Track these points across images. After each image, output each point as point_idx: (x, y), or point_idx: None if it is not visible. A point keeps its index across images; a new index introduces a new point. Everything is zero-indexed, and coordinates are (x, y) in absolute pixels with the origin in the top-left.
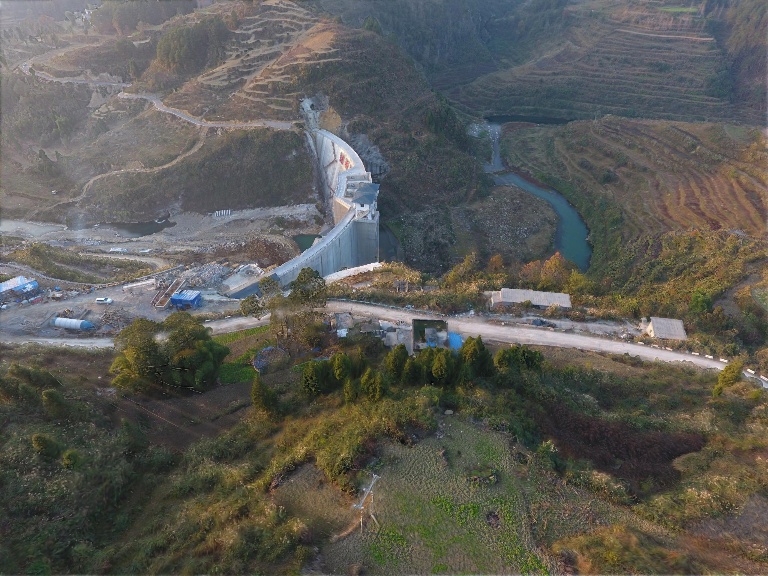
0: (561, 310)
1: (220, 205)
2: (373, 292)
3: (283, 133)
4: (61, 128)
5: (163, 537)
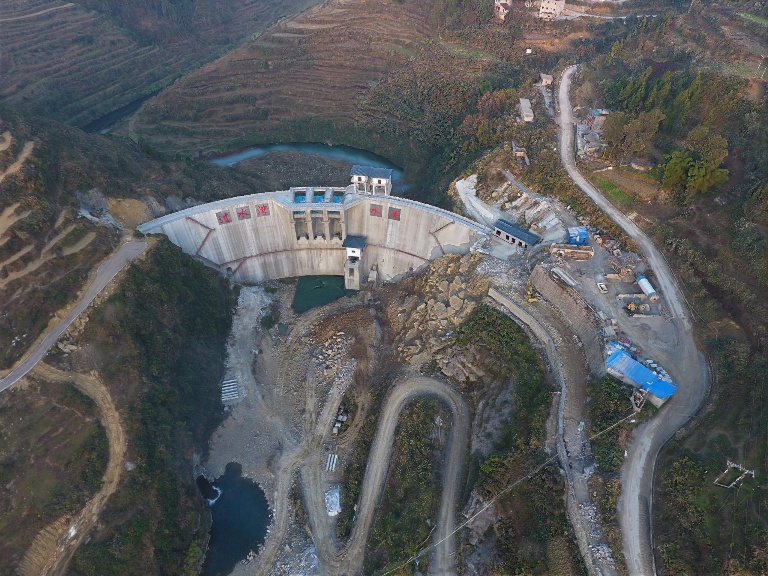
0: None
1: (213, 392)
2: None
3: (156, 250)
4: None
5: None
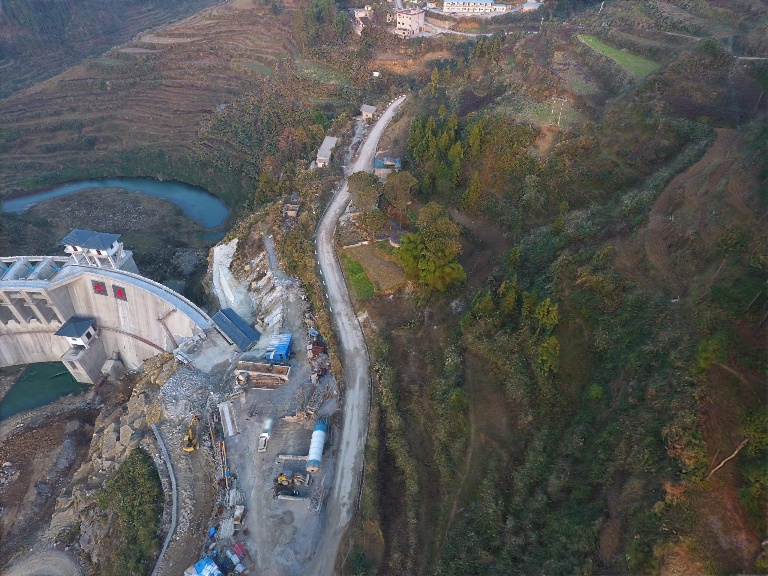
0: None
1: None
2: None
3: None
4: None
5: (584, 170)
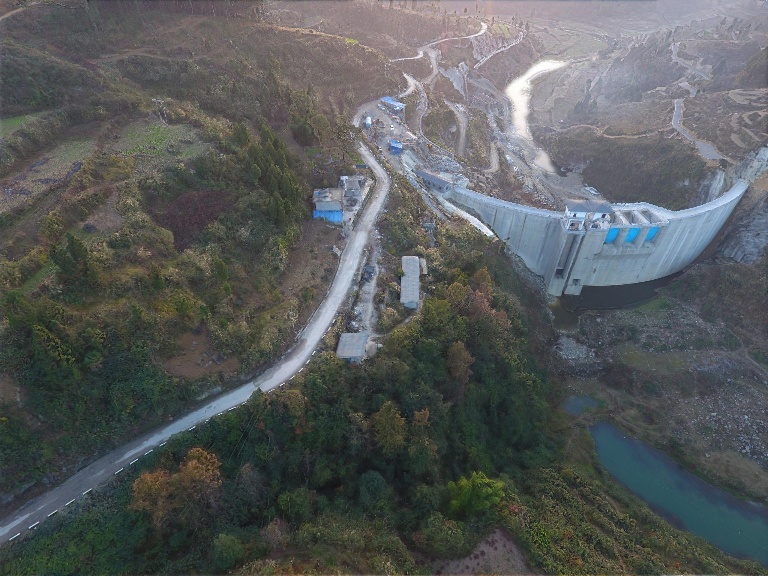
0: (394, 293)
1: None
2: (395, 192)
3: (695, 158)
4: (625, 89)
5: None
